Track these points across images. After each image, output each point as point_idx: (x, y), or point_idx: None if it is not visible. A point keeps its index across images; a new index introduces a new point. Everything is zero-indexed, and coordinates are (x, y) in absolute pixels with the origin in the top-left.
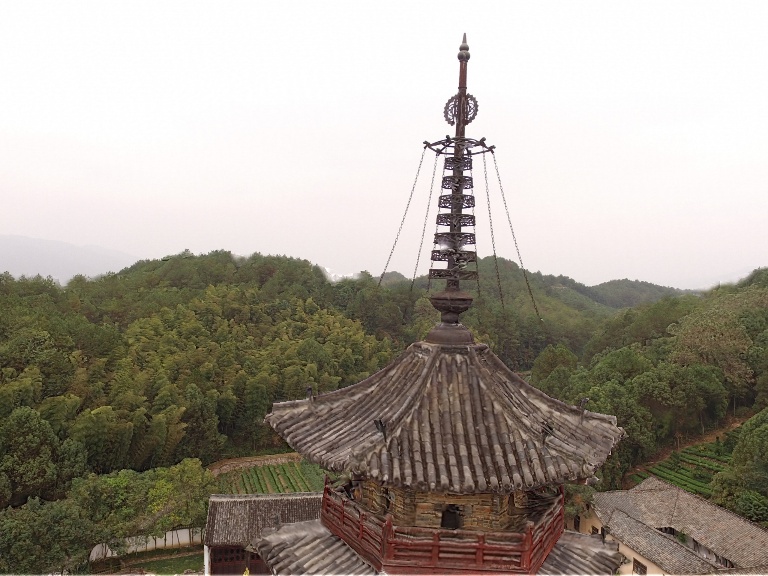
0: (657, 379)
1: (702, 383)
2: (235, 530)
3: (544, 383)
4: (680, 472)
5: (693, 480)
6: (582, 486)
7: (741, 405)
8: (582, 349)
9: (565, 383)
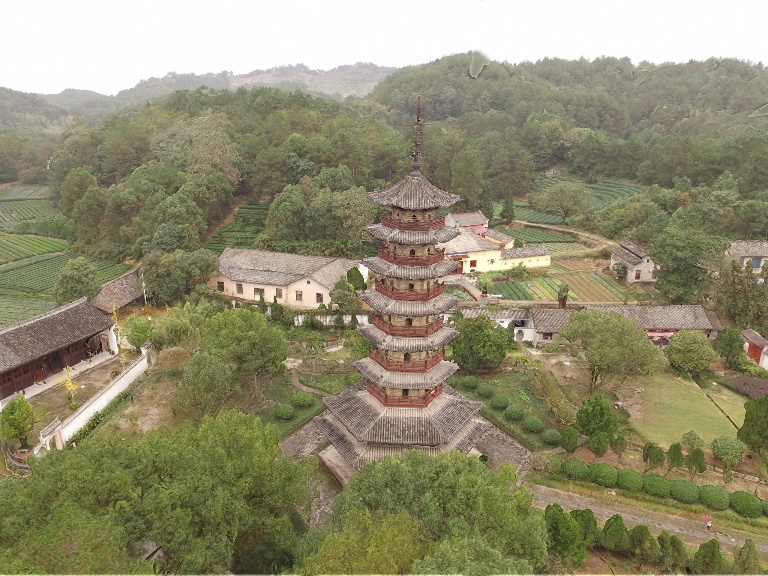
0: (197, 186)
1: (223, 185)
2: (7, 358)
3: (81, 203)
4: (226, 244)
5: (237, 246)
6: (216, 258)
7: (233, 196)
8: (12, 169)
9: (101, 200)
